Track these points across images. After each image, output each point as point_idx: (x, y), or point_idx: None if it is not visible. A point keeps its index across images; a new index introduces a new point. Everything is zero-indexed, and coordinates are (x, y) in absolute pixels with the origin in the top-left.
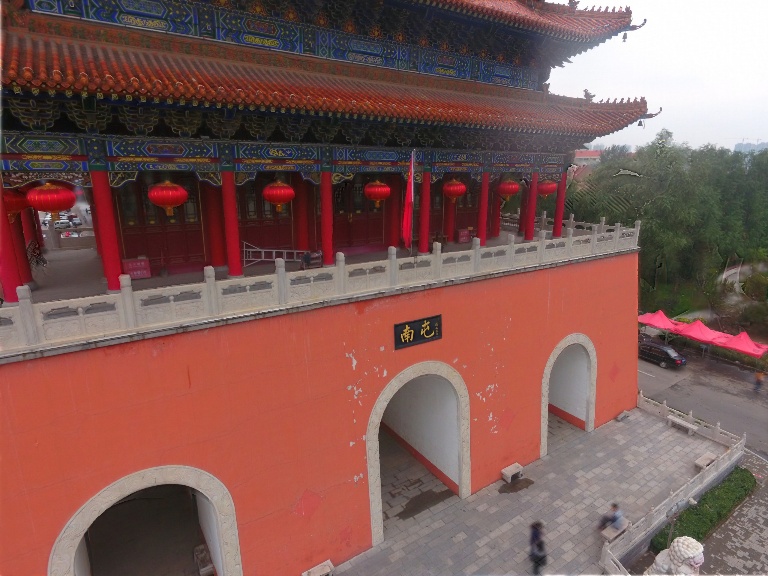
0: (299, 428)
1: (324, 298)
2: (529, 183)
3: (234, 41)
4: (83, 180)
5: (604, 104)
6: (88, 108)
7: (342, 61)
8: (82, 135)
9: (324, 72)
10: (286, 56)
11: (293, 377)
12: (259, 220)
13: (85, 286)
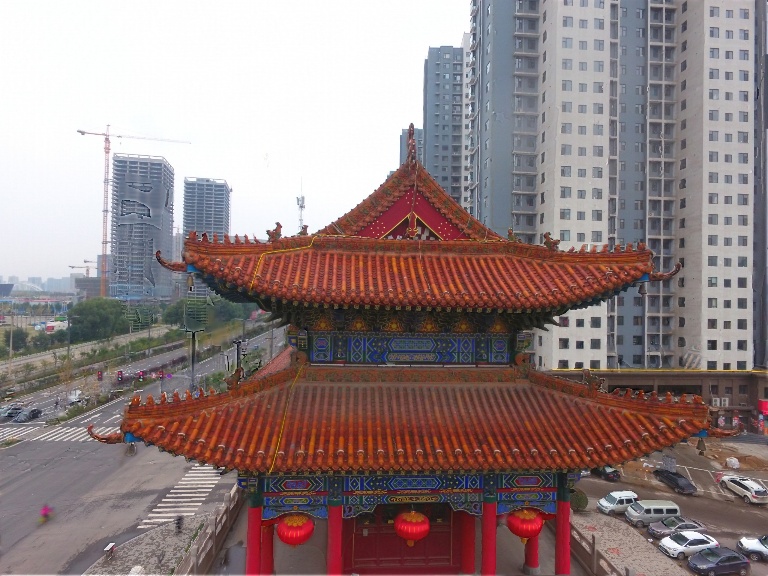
0: None
1: None
2: None
3: None
4: None
5: (206, 398)
6: None
7: None
8: None
9: None
10: None
11: None
12: None
13: None
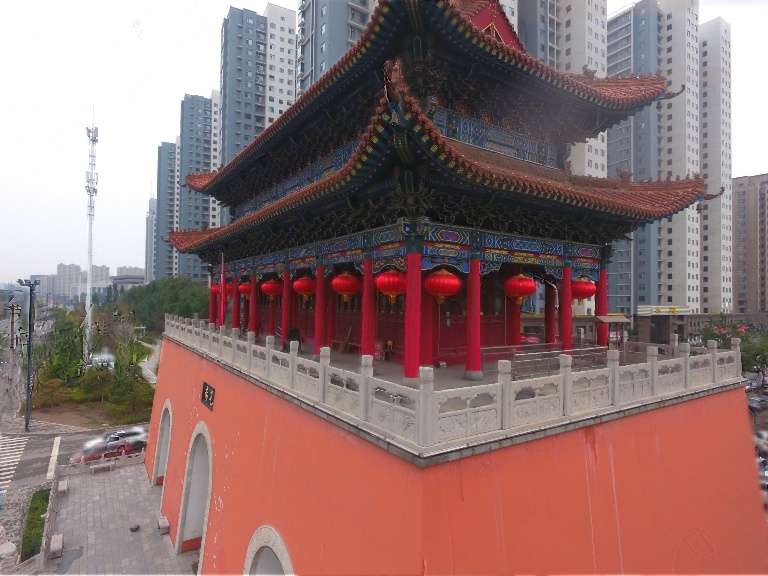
0: None
1: None
2: None
3: None
4: None
5: None
6: None
7: None
8: None
9: None
10: None
11: None
12: None
13: None
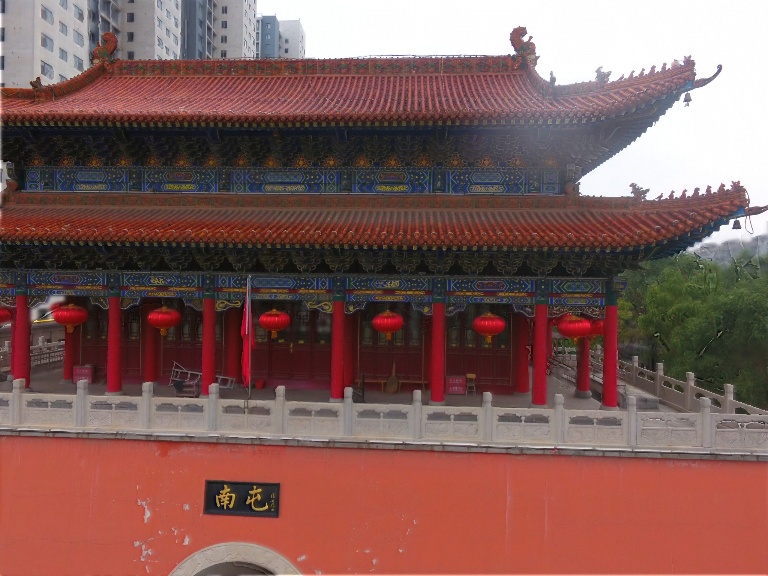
0: (71, 572)
1: (121, 429)
2: (531, 319)
3: (156, 190)
4: (12, 302)
5: (664, 200)
6: (3, 251)
7: (253, 194)
8: (13, 270)
9: (232, 206)
10: (195, 196)
11: (75, 509)
12: (191, 342)
13: (44, 383)
